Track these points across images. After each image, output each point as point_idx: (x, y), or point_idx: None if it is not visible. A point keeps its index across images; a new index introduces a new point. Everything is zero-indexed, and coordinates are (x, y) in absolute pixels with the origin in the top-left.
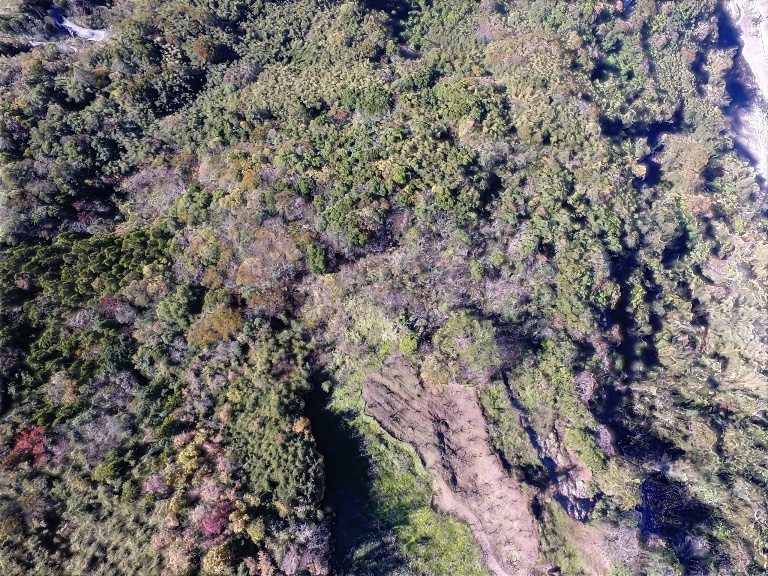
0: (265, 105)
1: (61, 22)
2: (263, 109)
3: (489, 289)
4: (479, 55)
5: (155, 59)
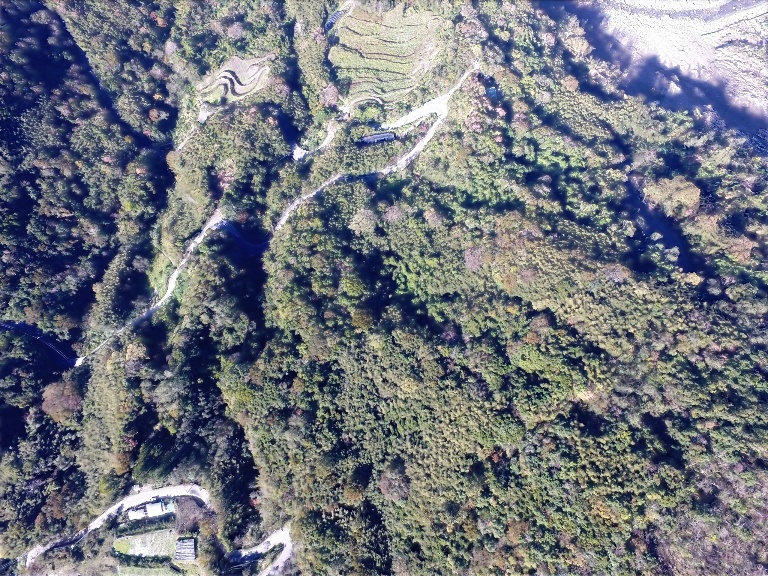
0: (444, 500)
1: (241, 554)
2: (445, 503)
3: (763, 537)
4: (491, 285)
5: (342, 535)
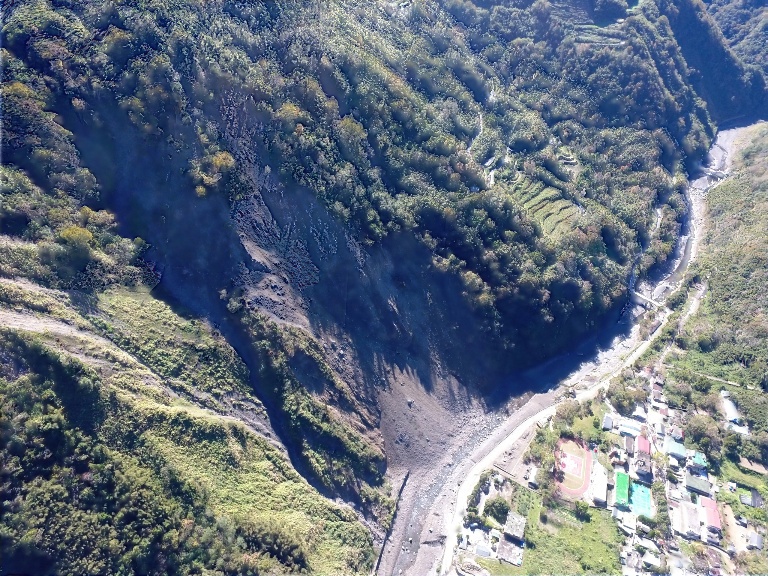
0: None
1: None
2: None
3: None
4: None
5: None
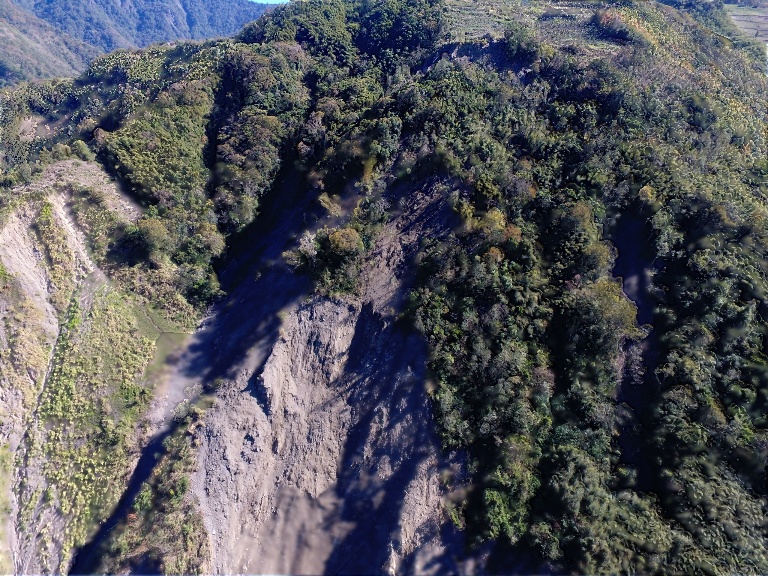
0: None
1: None
2: None
3: None
4: None
5: None
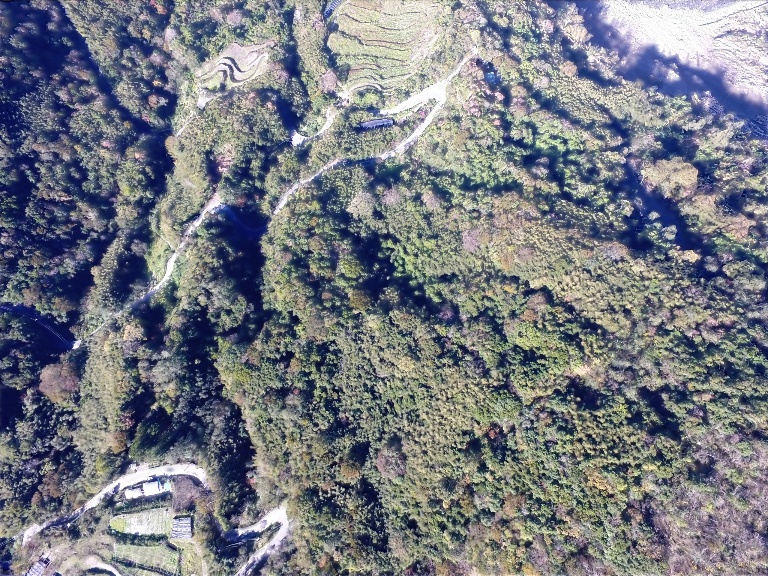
0: (441, 476)
1: (237, 533)
2: (441, 479)
3: (759, 507)
4: (488, 265)
5: (338, 512)
